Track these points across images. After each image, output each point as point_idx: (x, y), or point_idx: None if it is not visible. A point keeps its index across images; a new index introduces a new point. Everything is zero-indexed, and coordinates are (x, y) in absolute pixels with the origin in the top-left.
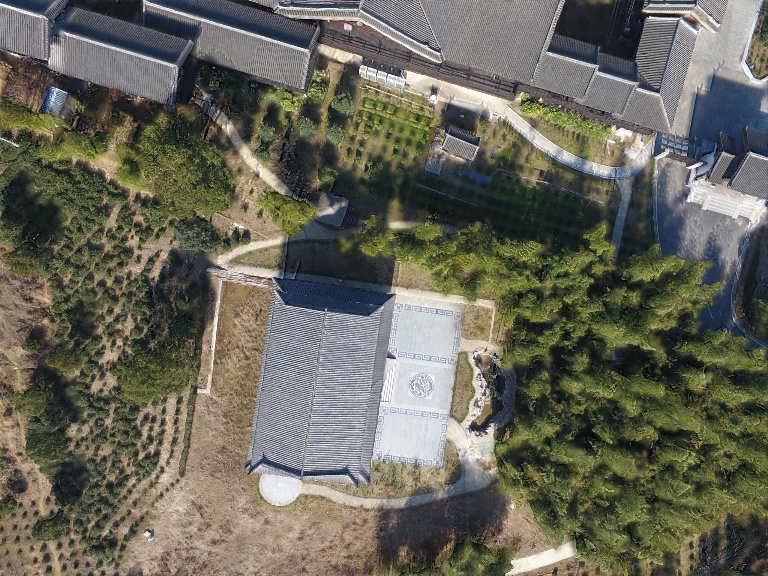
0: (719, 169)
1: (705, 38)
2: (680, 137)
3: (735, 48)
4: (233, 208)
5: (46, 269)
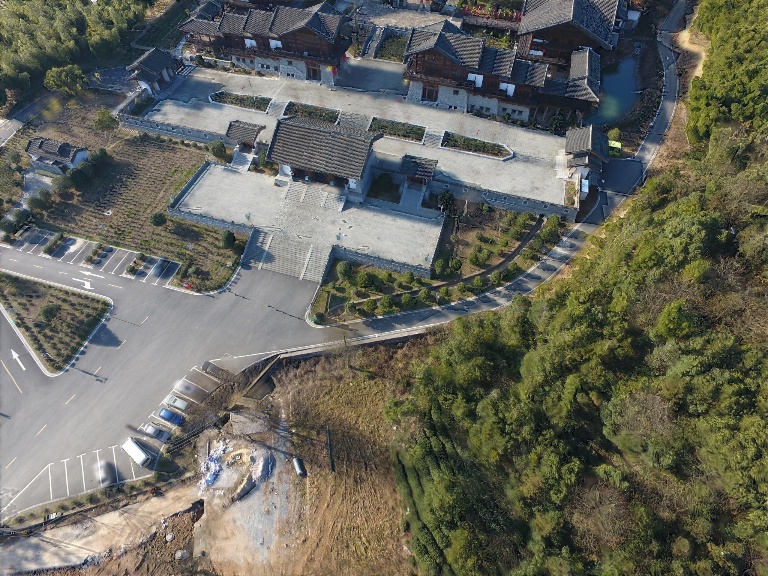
0: None
1: None
2: None
3: None
4: None
5: None
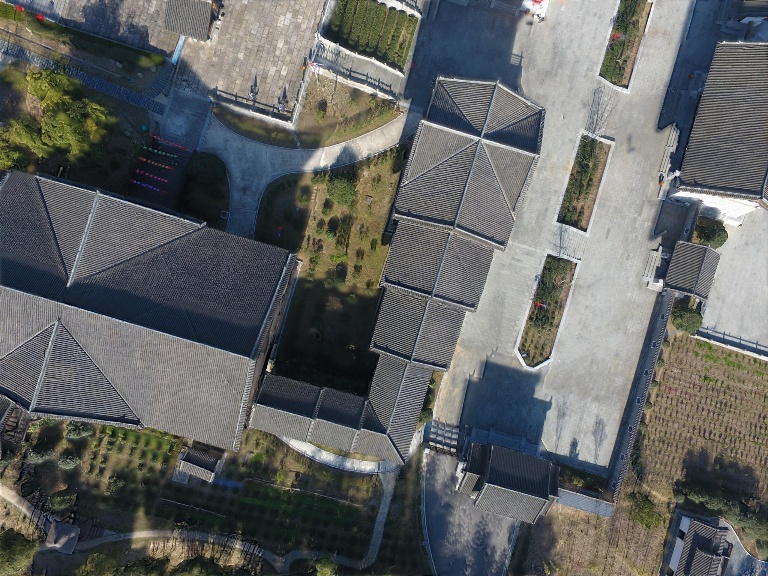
0: (468, 484)
1: (478, 325)
2: (450, 425)
3: (508, 335)
4: None
5: None
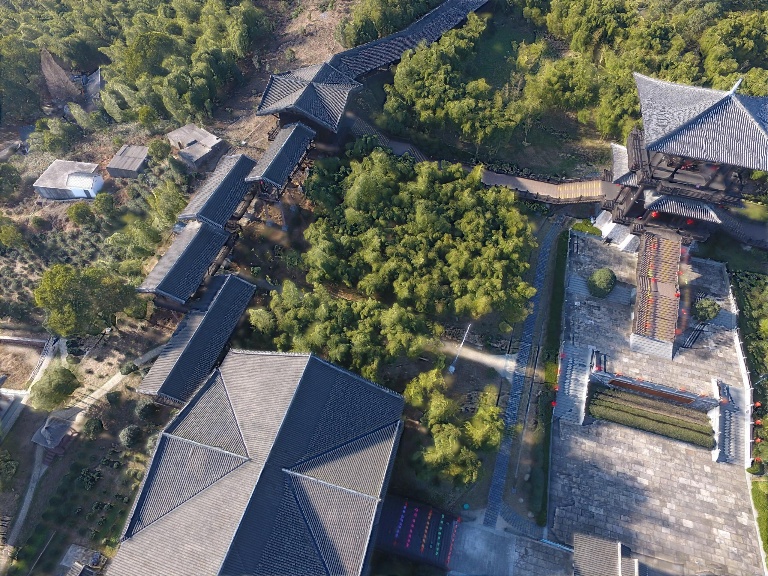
0: None
1: None
2: None
3: None
4: (102, 350)
5: (85, 228)
